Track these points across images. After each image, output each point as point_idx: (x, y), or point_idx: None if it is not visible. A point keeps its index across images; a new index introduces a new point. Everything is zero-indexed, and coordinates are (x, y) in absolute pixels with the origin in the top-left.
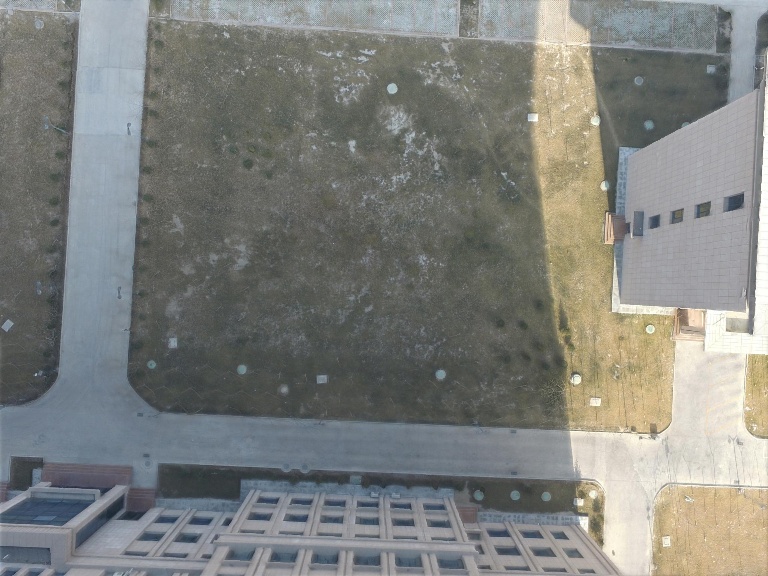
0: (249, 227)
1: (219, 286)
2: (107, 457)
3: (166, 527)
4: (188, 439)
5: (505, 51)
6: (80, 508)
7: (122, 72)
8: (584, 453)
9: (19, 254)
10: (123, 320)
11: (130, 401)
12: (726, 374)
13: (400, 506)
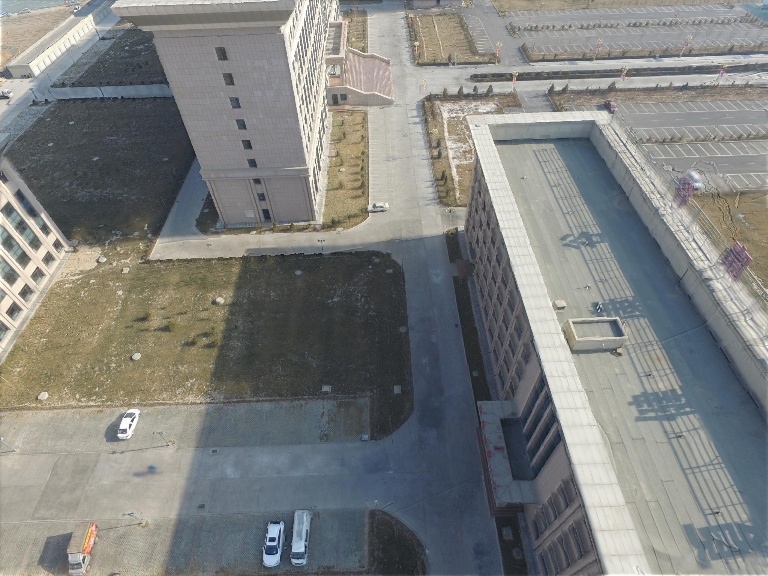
0: None
1: None
2: None
3: None
4: None
5: (125, 33)
6: None
7: (86, 91)
8: None
9: None
10: None
11: None
12: None
13: None
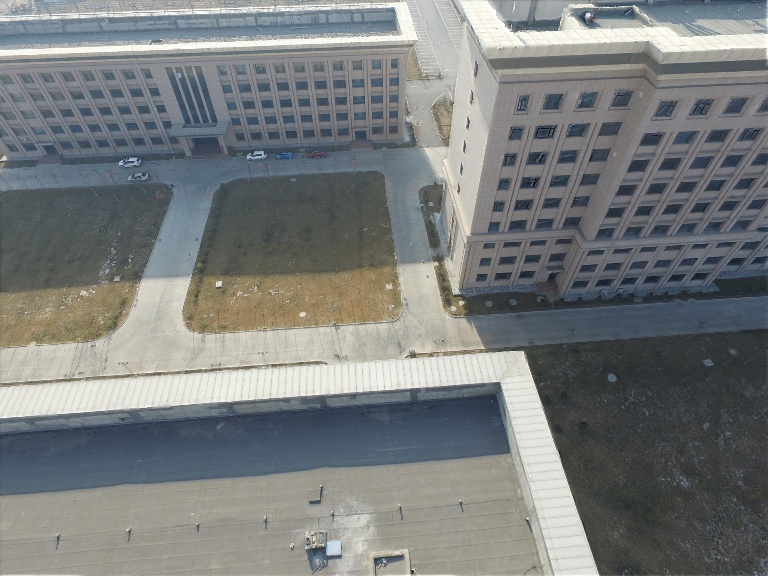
0: None
1: None
2: None
3: (762, 253)
4: None
5: None
6: None
7: None
8: (468, 335)
9: None
10: None
11: None
12: None
13: (602, 284)
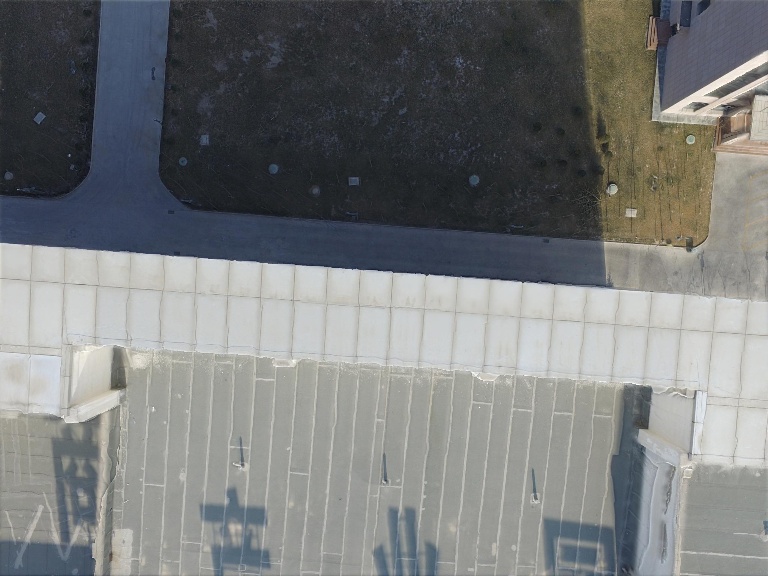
0: (283, 24)
1: (252, 84)
2: None
3: None
4: (218, 238)
5: None
6: None
7: None
8: (617, 265)
9: (51, 45)
10: (155, 115)
11: (161, 198)
12: (767, 188)
13: None
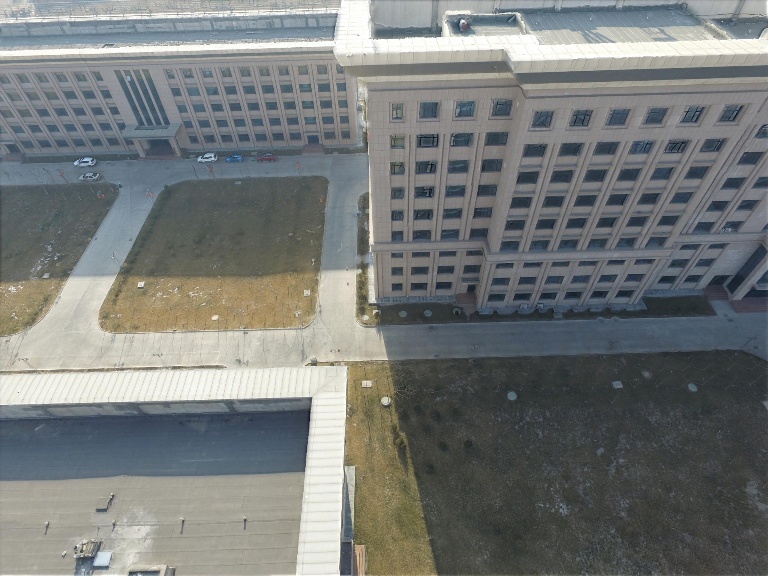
0: None
1: (760, 463)
2: (760, 318)
3: (694, 272)
4: (705, 333)
5: None
6: (767, 275)
7: None
8: (374, 345)
9: None
10: None
11: None
12: None
13: (521, 298)
